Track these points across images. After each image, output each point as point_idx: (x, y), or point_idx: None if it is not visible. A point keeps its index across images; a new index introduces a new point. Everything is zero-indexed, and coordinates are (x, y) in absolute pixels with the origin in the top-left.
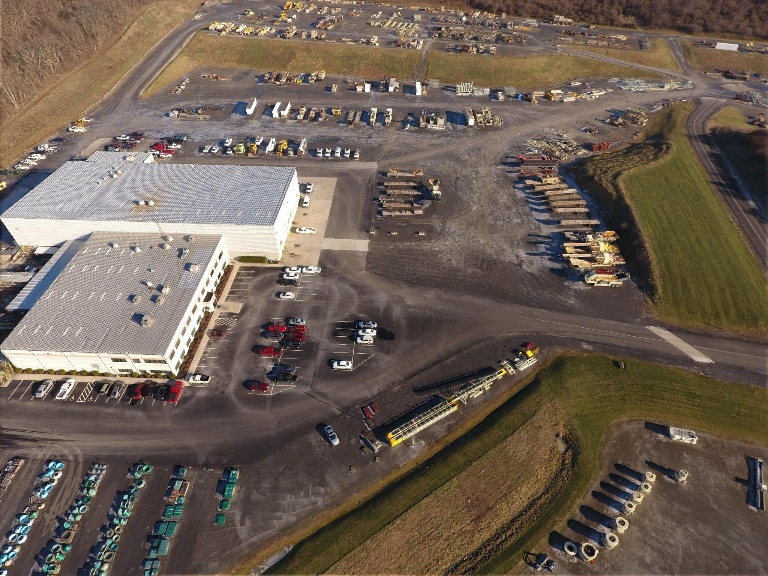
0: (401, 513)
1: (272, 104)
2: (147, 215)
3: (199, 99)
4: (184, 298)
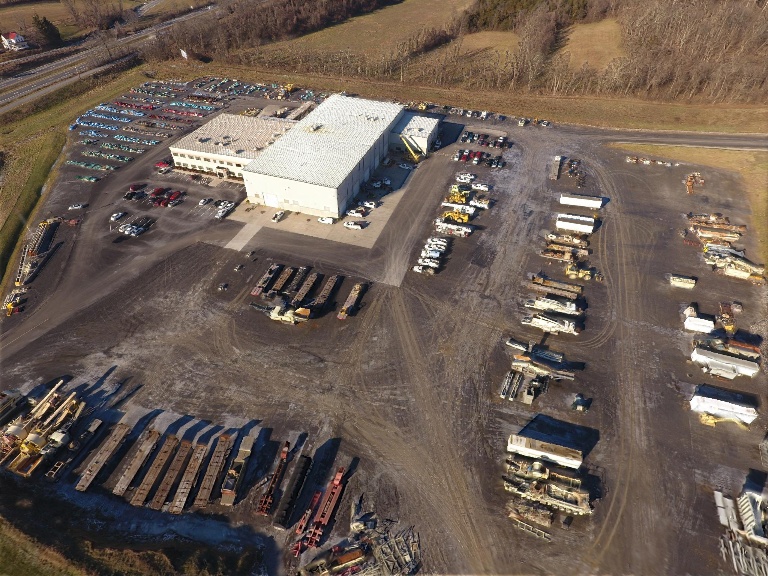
0: (6, 222)
1: (604, 221)
2: (298, 129)
3: (612, 173)
4: (209, 150)
